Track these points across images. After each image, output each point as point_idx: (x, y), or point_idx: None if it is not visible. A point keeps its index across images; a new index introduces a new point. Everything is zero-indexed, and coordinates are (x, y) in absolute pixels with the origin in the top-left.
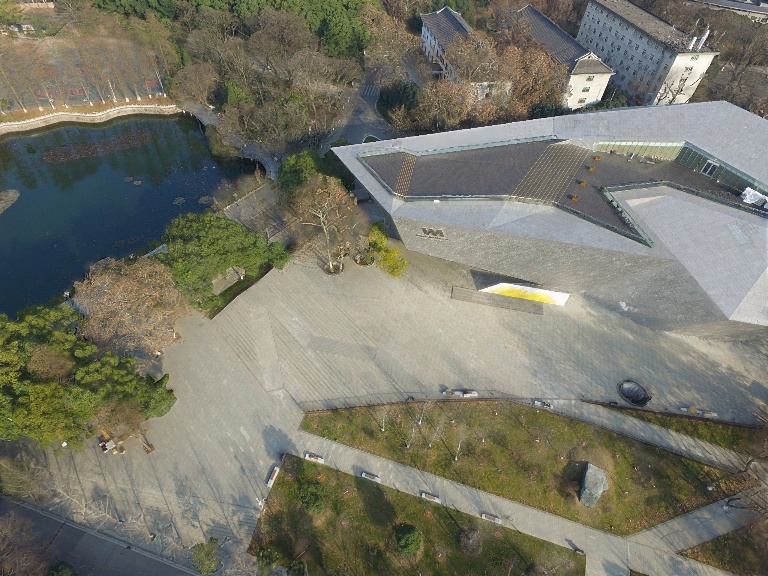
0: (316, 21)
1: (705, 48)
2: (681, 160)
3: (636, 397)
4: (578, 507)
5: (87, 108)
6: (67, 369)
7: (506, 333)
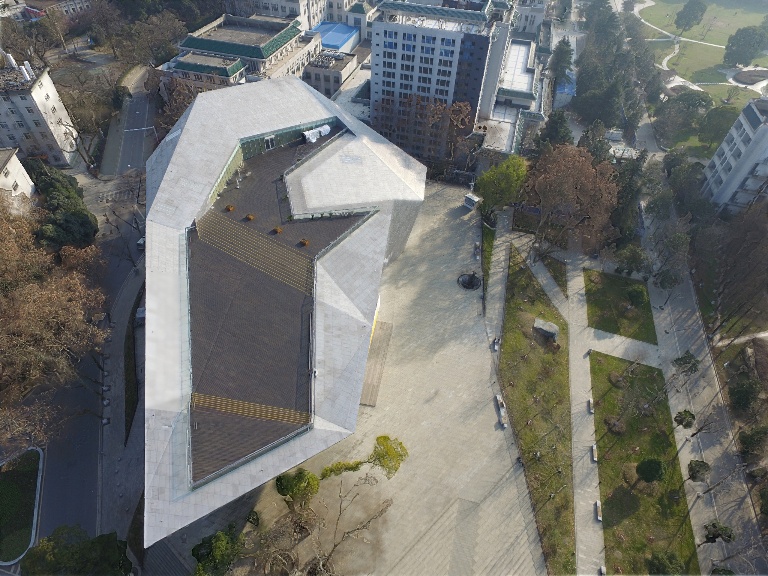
0: None
1: (36, 71)
2: (247, 155)
3: (464, 283)
4: (560, 345)
5: None
6: None
7: (420, 359)
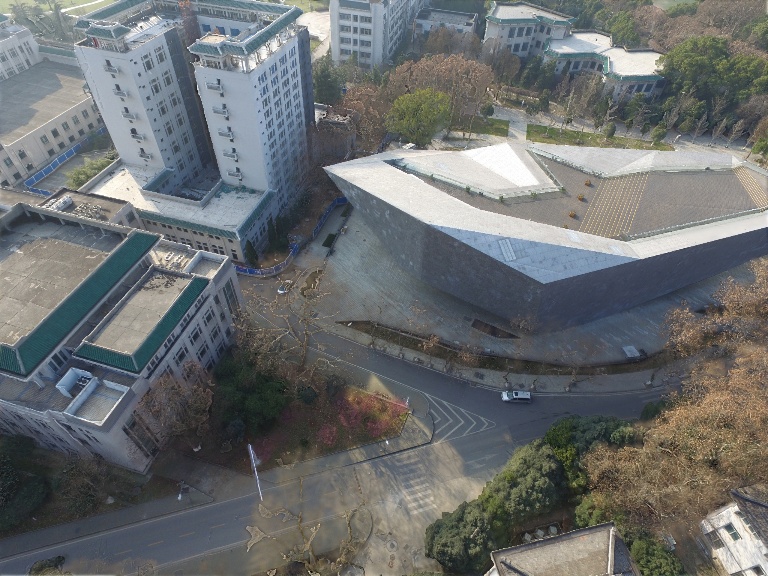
0: None
1: None
2: None
3: None
4: None
5: None
6: None
7: None
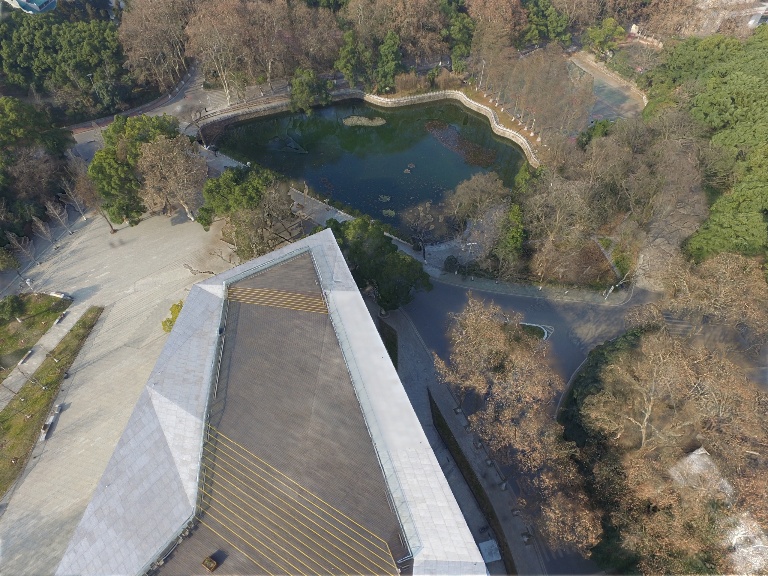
0: (760, 203)
1: None
2: None
3: None
4: None
5: (506, 119)
6: (120, 157)
7: None
